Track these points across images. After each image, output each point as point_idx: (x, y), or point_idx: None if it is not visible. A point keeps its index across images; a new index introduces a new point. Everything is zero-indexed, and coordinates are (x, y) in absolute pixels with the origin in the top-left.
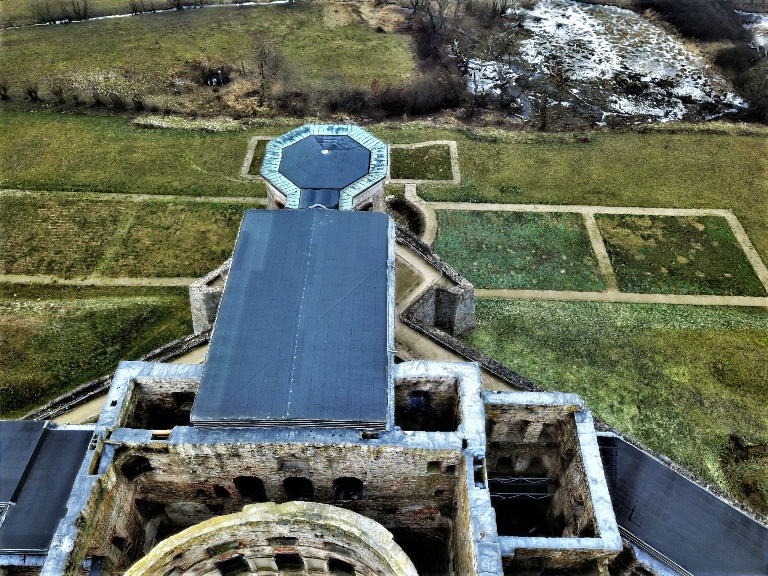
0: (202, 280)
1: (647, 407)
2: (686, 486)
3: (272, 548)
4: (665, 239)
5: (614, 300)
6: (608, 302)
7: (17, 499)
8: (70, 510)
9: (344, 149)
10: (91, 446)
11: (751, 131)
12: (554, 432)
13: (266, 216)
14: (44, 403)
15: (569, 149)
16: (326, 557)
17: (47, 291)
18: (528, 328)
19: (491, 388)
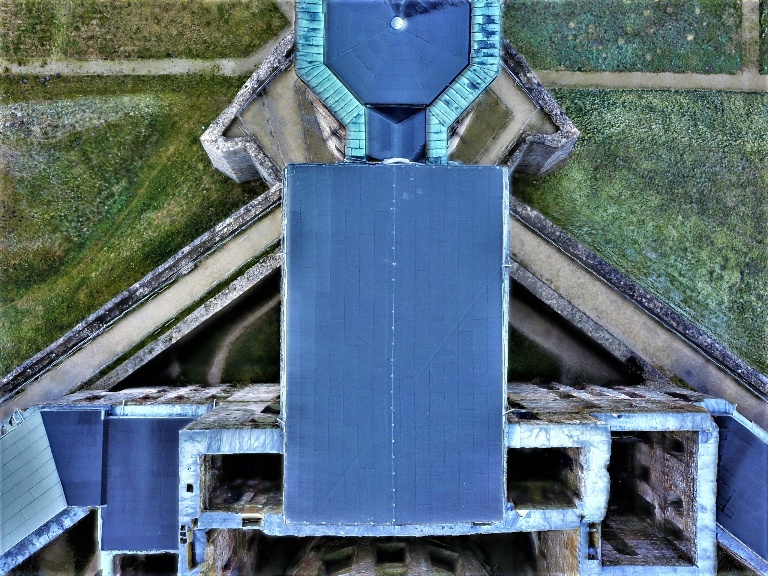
0: (215, 128)
1: (752, 272)
2: None
3: None
4: None
5: (748, 88)
6: (739, 93)
7: (106, 500)
8: None
9: (428, 8)
10: (181, 539)
11: None
12: None
13: (321, 180)
14: (67, 273)
15: None
16: None
17: (3, 87)
18: (632, 158)
19: (585, 289)
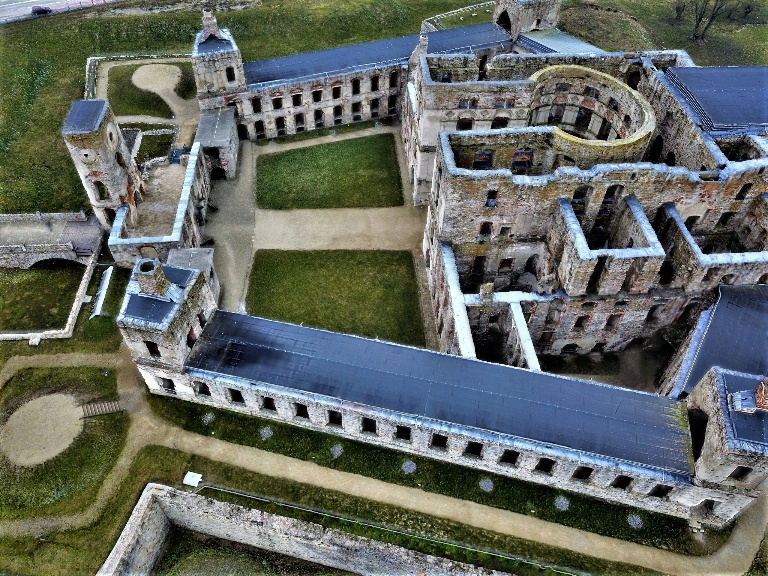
0: None
1: None
2: None
3: None
4: None
5: None
6: None
7: None
8: None
9: None
10: None
11: None
12: None
13: None
14: None
15: None
16: None
17: None
18: None
19: None
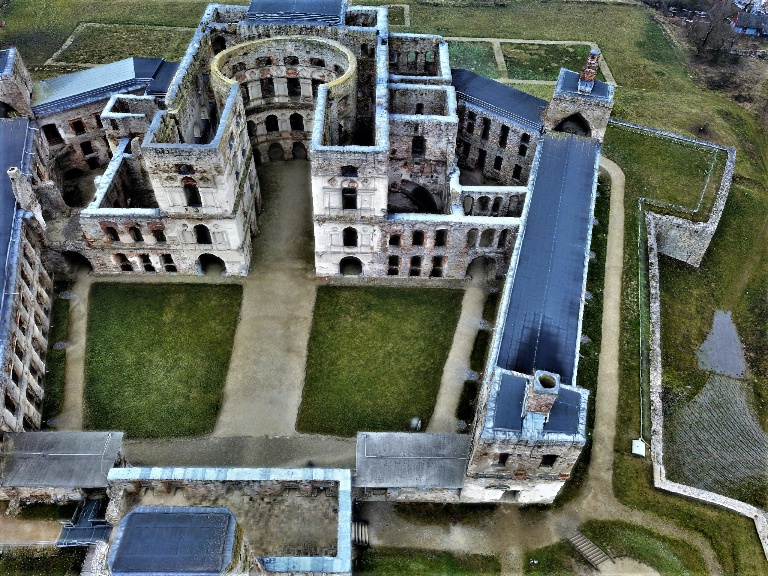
0: None
1: None
2: (496, 83)
3: (286, 69)
4: (545, 55)
5: None
6: None
7: (155, 79)
8: (195, 38)
9: None
10: (200, 25)
11: (623, 3)
12: (433, 68)
13: None
14: None
15: (489, 10)
16: (311, 77)
17: None
18: None
19: None
